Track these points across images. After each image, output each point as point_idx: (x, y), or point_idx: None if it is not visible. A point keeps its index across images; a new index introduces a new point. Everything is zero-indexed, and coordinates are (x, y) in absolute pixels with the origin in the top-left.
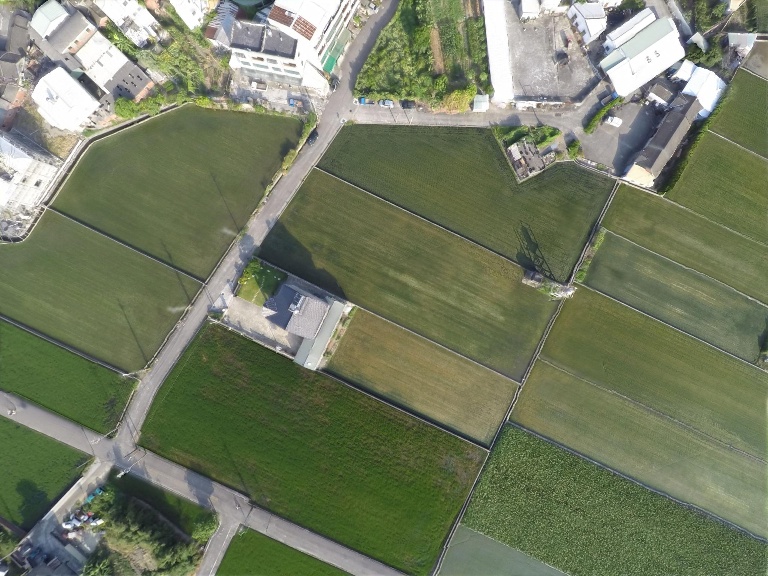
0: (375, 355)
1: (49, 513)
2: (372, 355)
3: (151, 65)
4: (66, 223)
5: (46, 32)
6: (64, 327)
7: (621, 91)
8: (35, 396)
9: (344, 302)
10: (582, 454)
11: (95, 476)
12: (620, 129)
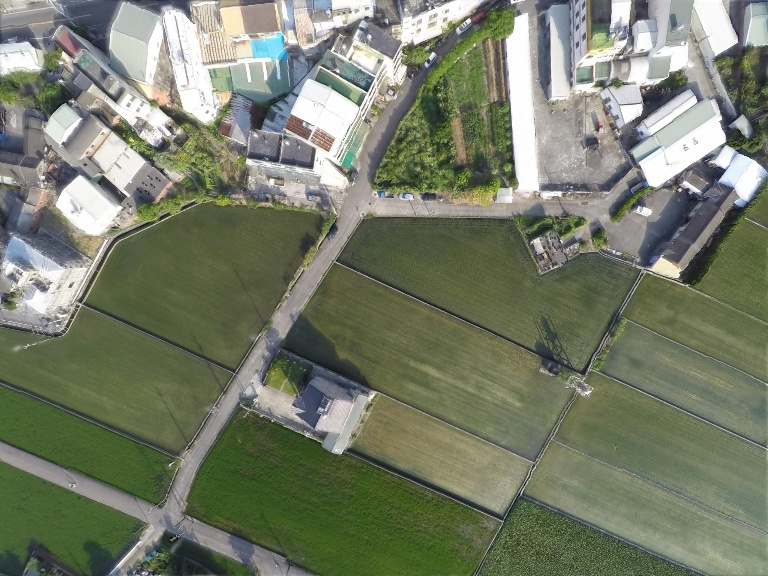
0: (397, 437)
1: (115, 569)
2: (394, 437)
3: (168, 168)
4: (101, 318)
5: (62, 139)
6: (110, 412)
7: (653, 182)
8: (91, 472)
9: (367, 392)
10: (590, 523)
11: (151, 540)
12: (649, 217)
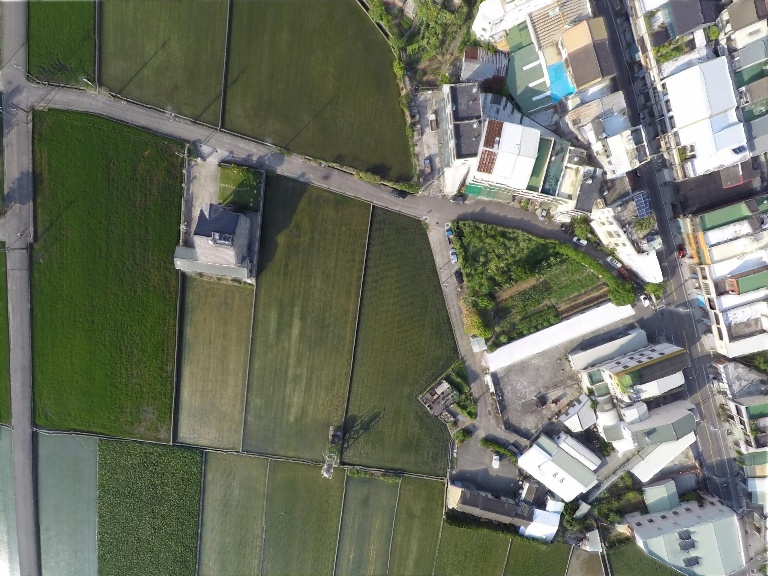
0: (217, 318)
1: None
2: (215, 315)
3: None
4: None
5: None
6: None
7: (522, 460)
8: None
9: (252, 275)
10: (202, 518)
11: None
12: (492, 467)
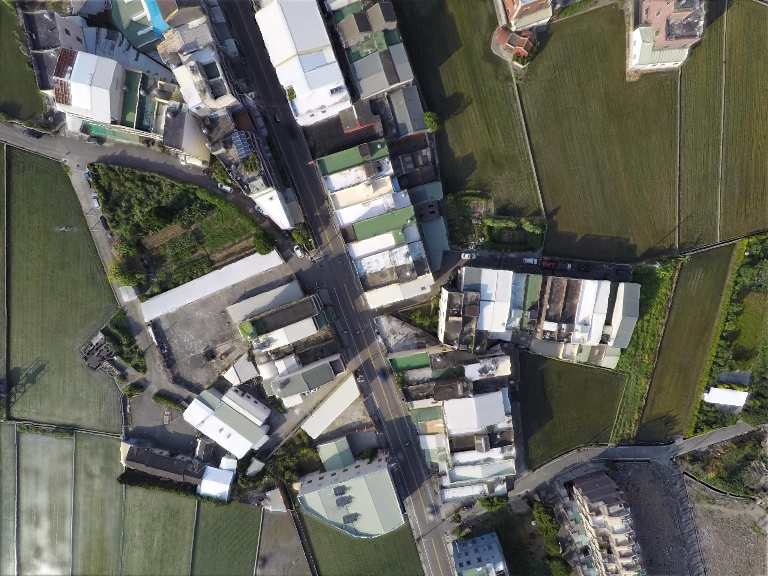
0: None
1: None
2: None
3: None
4: None
5: None
6: None
7: (187, 415)
8: None
9: None
10: None
11: None
12: (168, 424)
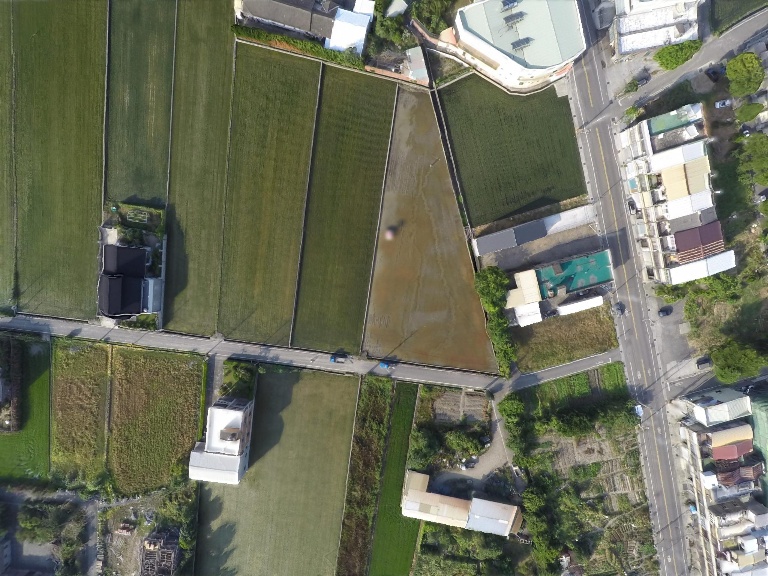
0: None
1: None
2: None
3: None
4: None
5: None
6: None
7: None
8: None
9: None
10: None
11: None
12: None
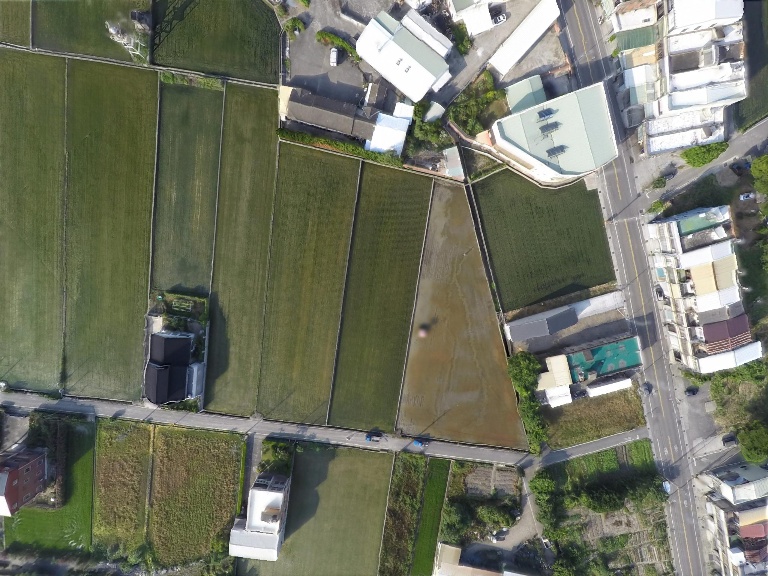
0: None
1: None
2: None
3: None
4: None
5: None
6: None
7: (360, 45)
8: None
9: None
10: None
11: None
12: (332, 71)
